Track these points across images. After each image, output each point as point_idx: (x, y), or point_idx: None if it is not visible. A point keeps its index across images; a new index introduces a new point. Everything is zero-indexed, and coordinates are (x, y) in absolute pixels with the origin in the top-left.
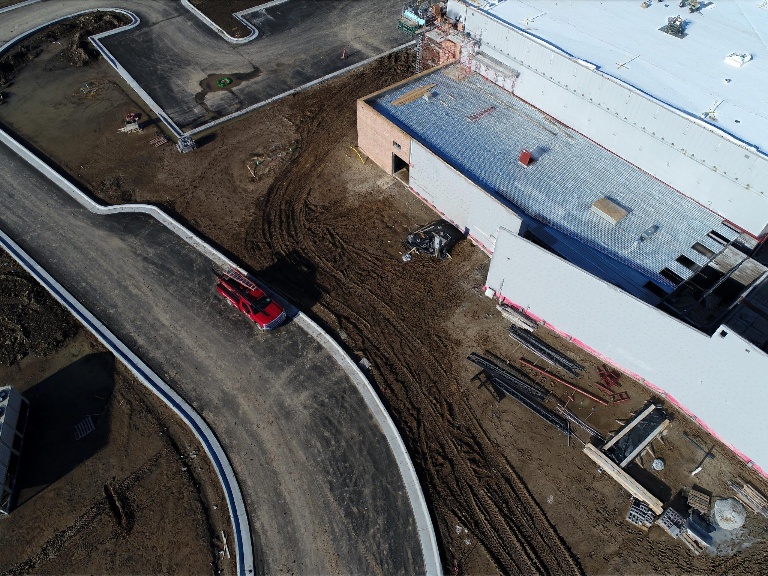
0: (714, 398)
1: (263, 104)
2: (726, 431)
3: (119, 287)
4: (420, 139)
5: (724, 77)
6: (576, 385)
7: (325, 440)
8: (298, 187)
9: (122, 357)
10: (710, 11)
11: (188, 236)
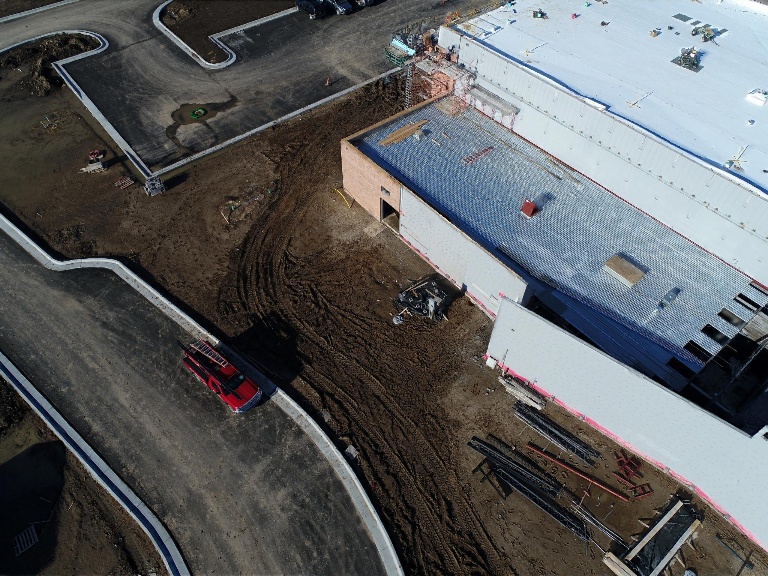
0: (753, 500)
1: (240, 138)
2: (766, 536)
3: (73, 360)
4: (411, 185)
5: (747, 118)
6: (592, 476)
7: (306, 551)
8: (277, 236)
9: (73, 448)
10: (725, 39)
11: (153, 296)
